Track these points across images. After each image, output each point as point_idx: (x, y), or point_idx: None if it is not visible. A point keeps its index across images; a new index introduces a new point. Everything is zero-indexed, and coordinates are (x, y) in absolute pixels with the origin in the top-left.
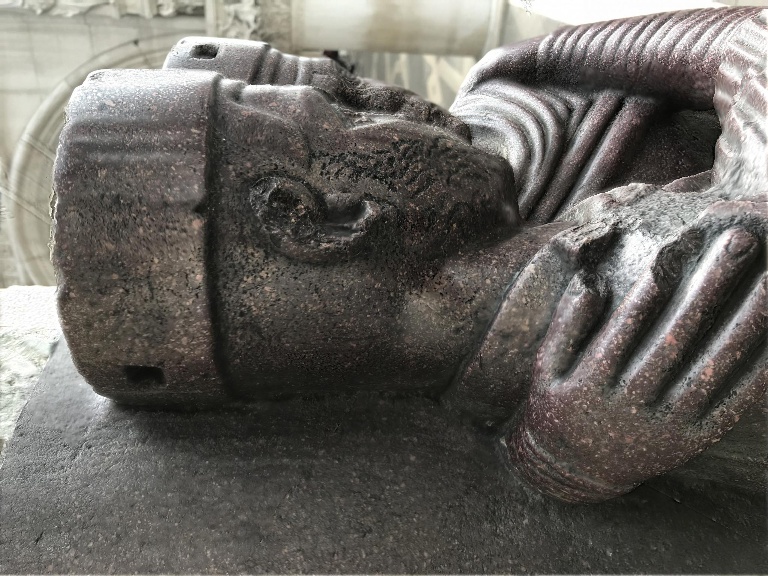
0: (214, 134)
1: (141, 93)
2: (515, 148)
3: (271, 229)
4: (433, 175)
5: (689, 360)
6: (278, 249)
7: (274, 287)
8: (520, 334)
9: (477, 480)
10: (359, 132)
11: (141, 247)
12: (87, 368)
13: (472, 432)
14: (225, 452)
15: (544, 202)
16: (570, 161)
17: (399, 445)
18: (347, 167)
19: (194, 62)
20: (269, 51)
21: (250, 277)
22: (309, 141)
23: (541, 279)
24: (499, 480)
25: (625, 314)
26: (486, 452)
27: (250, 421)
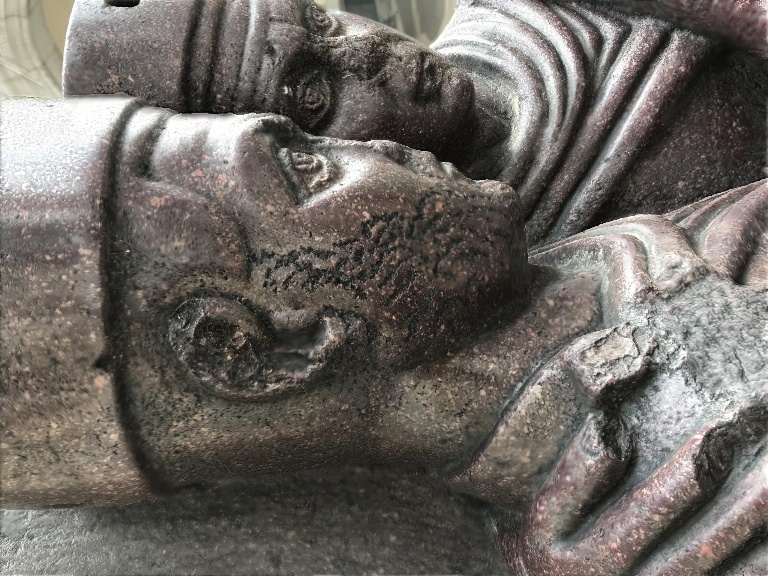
0: (113, 246)
1: (5, 185)
2: (530, 100)
3: (200, 374)
4: (415, 265)
5: (726, 569)
6: (213, 393)
7: (213, 427)
8: (519, 464)
9: (464, 561)
10: (316, 211)
11: (31, 414)
12: (1, 507)
13: (460, 505)
14: (184, 538)
15: (561, 177)
16: (597, 121)
17: (378, 523)
18: (299, 271)
19: (111, 14)
20: None
21: (181, 421)
22: (247, 235)
23: (549, 407)
24: (488, 562)
25: (652, 507)
26: (475, 528)
27: (210, 499)
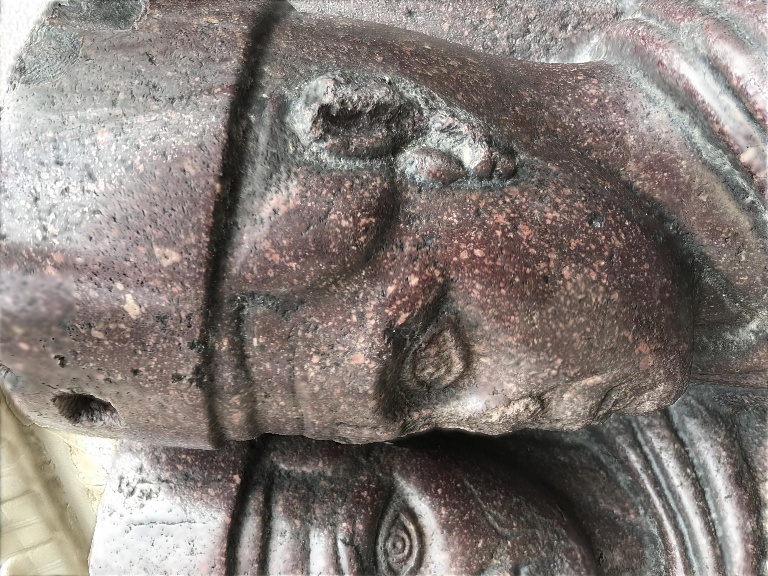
0: None
1: None
2: None
3: None
4: None
5: None
6: None
7: None
8: None
9: None
10: None
11: None
12: None
13: None
14: None
15: None
16: None
17: None
18: None
19: (90, 429)
20: (217, 372)
21: None
22: None
23: None
24: None
25: None
26: None
27: None
